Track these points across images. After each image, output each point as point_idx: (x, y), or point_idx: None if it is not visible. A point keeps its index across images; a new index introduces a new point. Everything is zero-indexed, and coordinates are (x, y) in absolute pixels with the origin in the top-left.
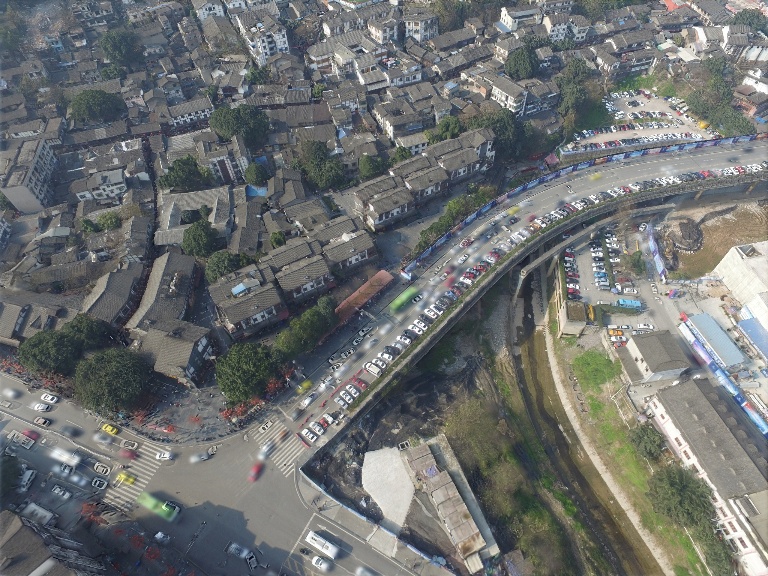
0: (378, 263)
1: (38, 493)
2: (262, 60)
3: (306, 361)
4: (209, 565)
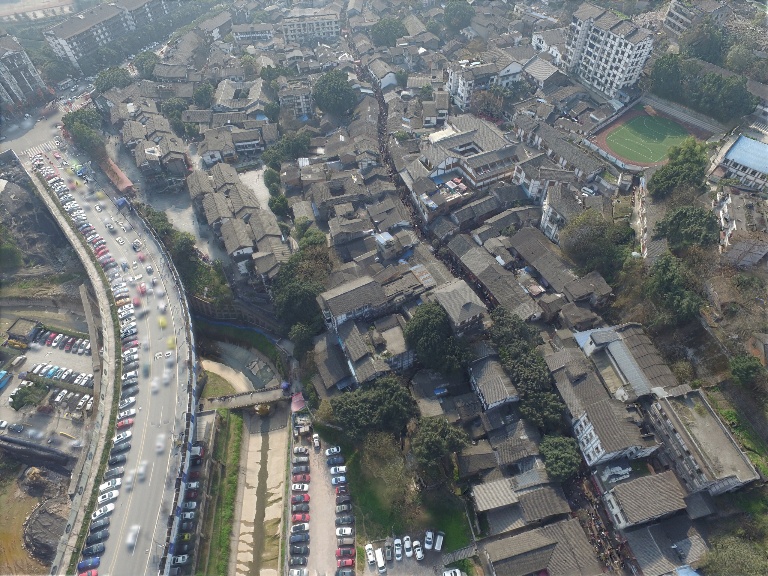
0: (149, 188)
1: (82, 83)
2: (447, 89)
3: (87, 155)
4: (3, 132)
